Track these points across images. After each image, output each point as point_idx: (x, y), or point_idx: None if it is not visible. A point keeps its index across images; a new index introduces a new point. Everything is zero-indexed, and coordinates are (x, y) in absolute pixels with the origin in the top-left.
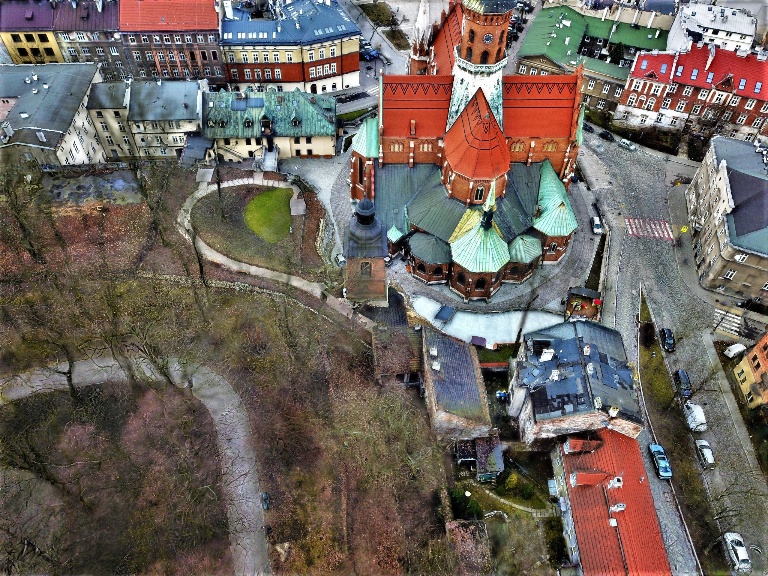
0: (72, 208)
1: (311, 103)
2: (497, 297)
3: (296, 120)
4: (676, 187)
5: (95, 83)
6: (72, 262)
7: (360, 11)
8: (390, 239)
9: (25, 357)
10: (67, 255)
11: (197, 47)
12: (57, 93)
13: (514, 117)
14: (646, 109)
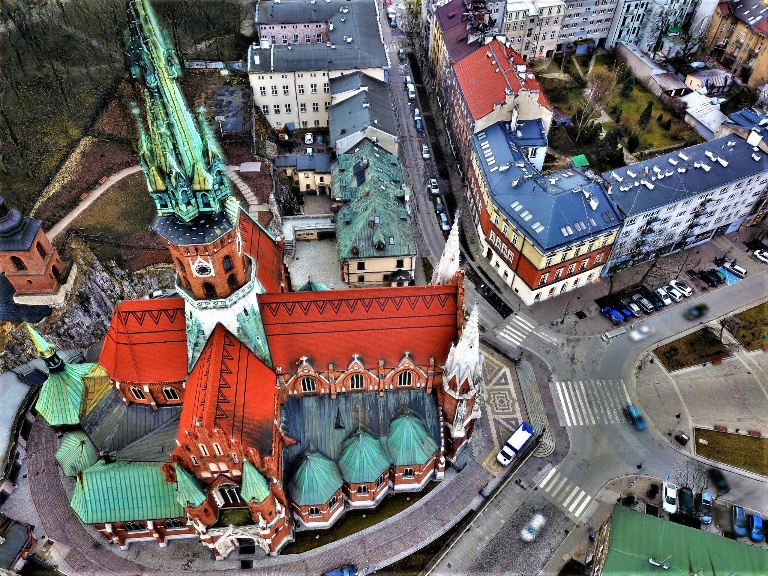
0: (203, 104)
1: (368, 222)
2: None
3: (345, 218)
4: None
5: (364, 74)
6: (129, 112)
7: (765, 298)
8: None
9: (6, 99)
10: (142, 110)
11: (466, 124)
12: (328, 55)
13: None
14: None
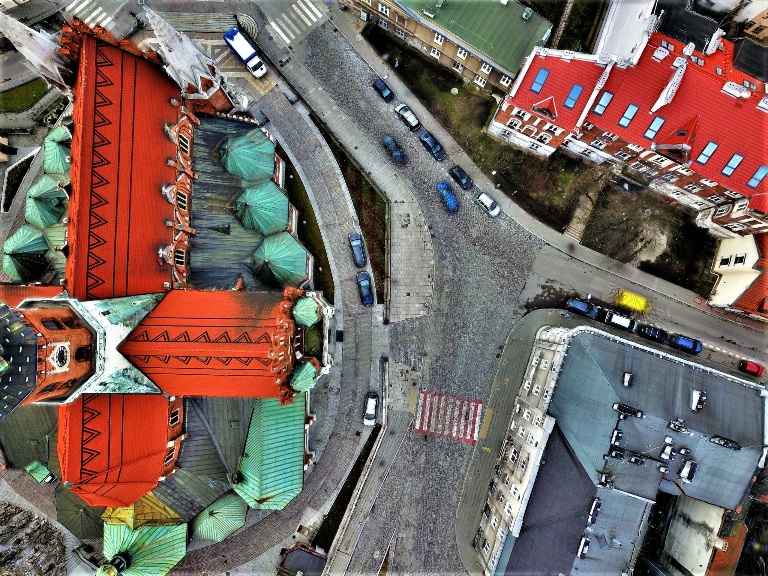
0: None
1: None
2: (196, 541)
3: None
4: (529, 317)
5: None
6: None
7: None
8: (33, 477)
9: None
10: None
11: None
12: None
13: (174, 380)
14: (537, 140)
